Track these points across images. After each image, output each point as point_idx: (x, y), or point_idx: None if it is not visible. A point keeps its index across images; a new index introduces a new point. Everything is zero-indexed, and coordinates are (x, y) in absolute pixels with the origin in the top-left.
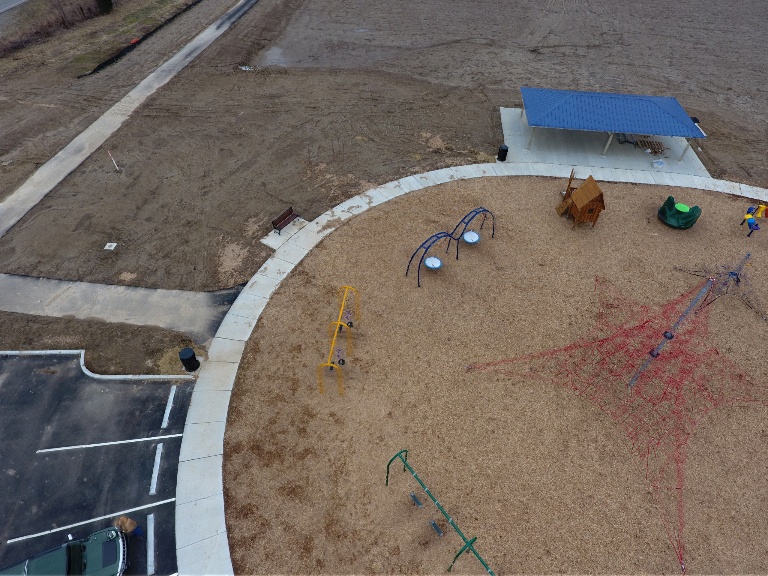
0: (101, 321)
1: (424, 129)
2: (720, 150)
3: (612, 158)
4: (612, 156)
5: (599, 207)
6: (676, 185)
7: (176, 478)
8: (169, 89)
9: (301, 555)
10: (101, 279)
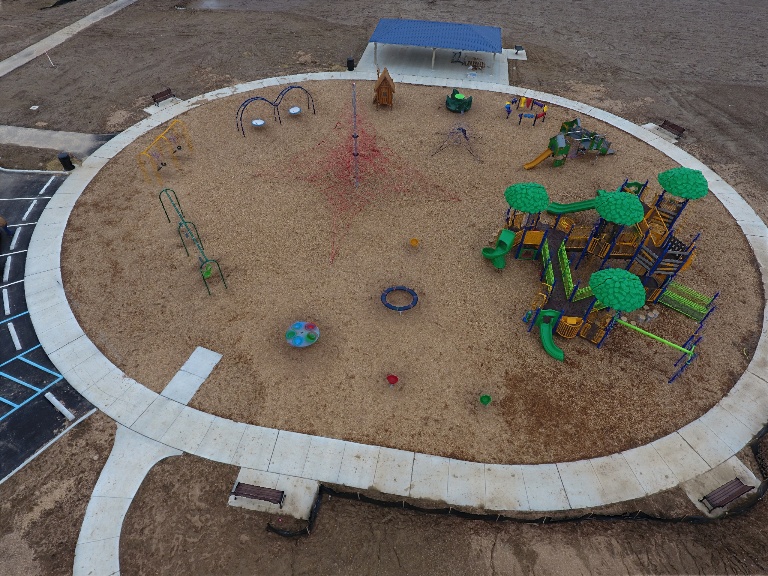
0: (16, 145)
1: (301, 49)
2: (530, 69)
3: (439, 71)
4: (439, 70)
5: (390, 91)
6: (476, 88)
7: (40, 215)
8: (111, 19)
9: (103, 247)
10: (22, 124)
